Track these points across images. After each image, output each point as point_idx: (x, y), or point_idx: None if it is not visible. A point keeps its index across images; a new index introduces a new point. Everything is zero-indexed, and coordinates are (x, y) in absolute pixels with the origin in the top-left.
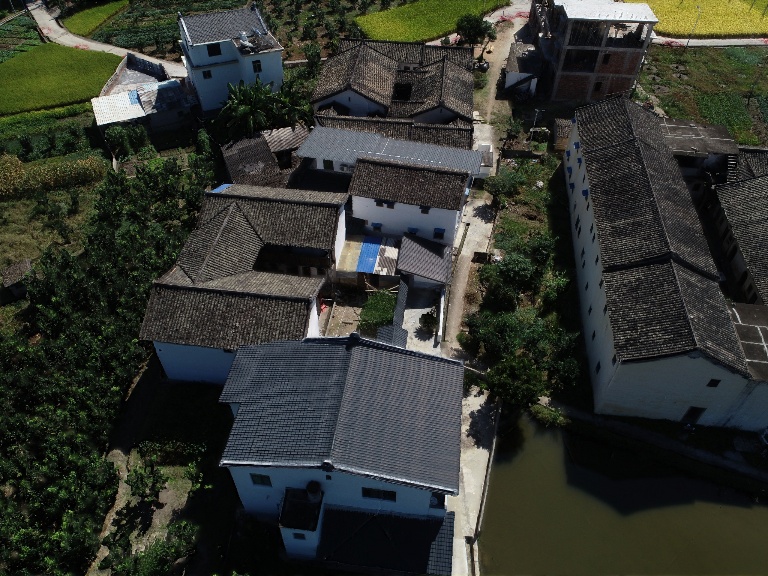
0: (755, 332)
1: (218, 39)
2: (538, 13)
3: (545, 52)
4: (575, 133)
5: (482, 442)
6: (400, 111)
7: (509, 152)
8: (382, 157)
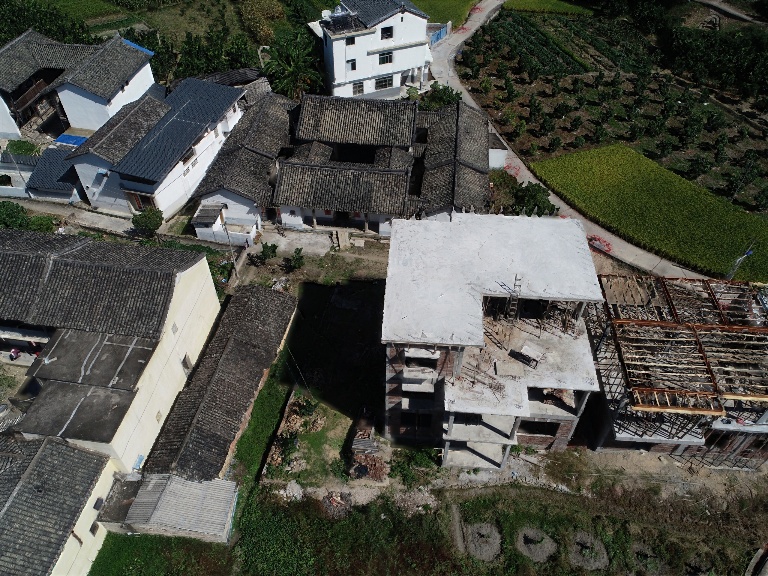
0: None
1: (352, 9)
2: None
3: None
4: None
5: None
6: (301, 151)
7: (242, 255)
8: (167, 118)
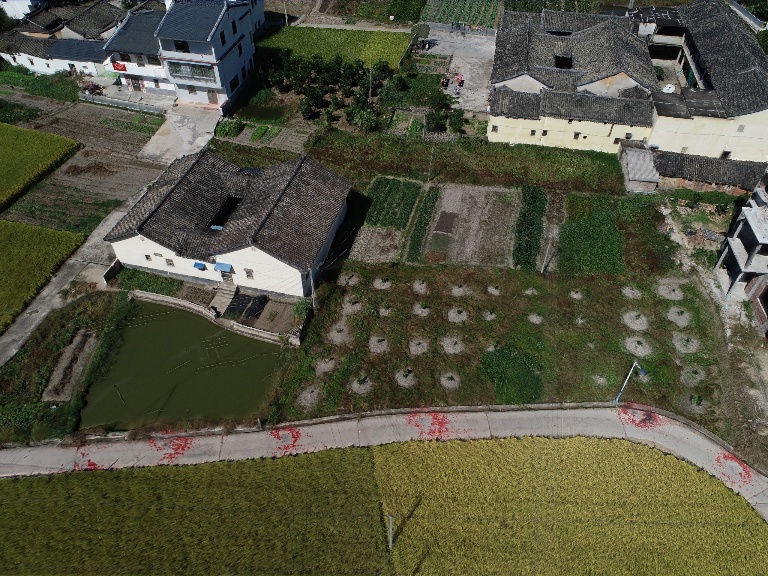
0: (672, 17)
1: None
2: None
3: None
4: None
5: (767, 50)
6: None
7: None
8: None
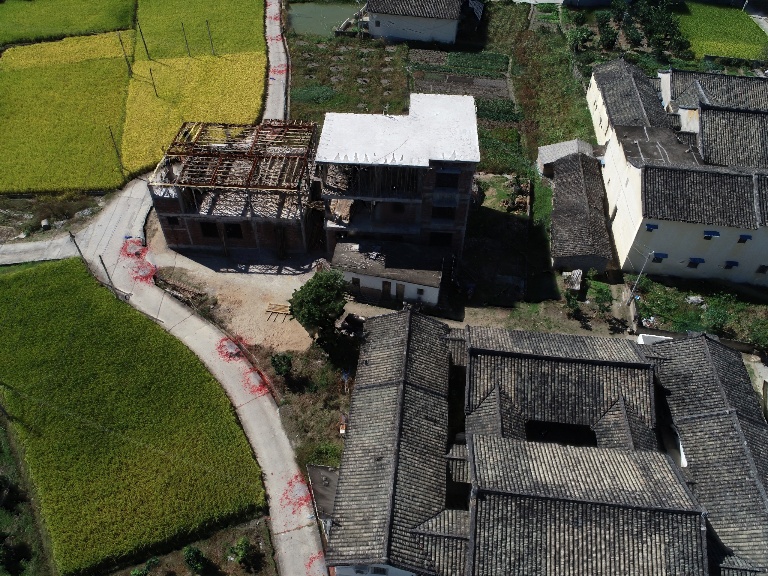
0: None
1: None
2: (240, 217)
3: (401, 229)
4: (672, 232)
5: None
6: (647, 441)
7: None
8: None
